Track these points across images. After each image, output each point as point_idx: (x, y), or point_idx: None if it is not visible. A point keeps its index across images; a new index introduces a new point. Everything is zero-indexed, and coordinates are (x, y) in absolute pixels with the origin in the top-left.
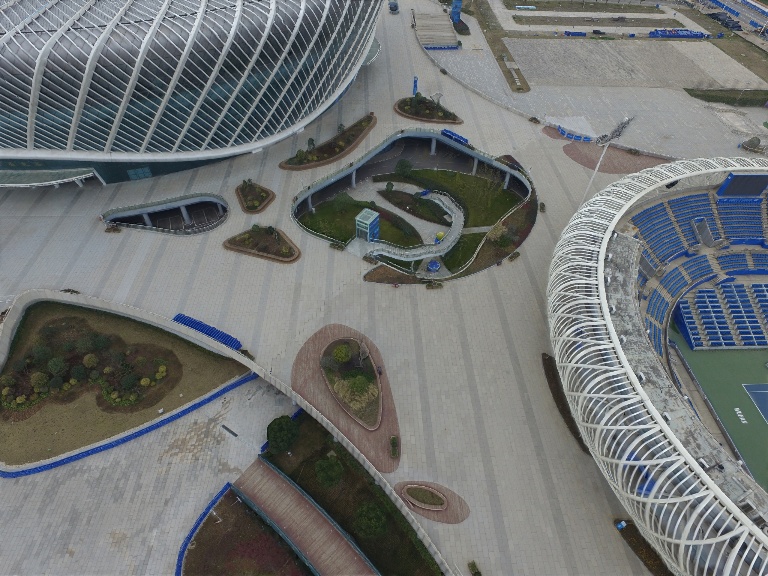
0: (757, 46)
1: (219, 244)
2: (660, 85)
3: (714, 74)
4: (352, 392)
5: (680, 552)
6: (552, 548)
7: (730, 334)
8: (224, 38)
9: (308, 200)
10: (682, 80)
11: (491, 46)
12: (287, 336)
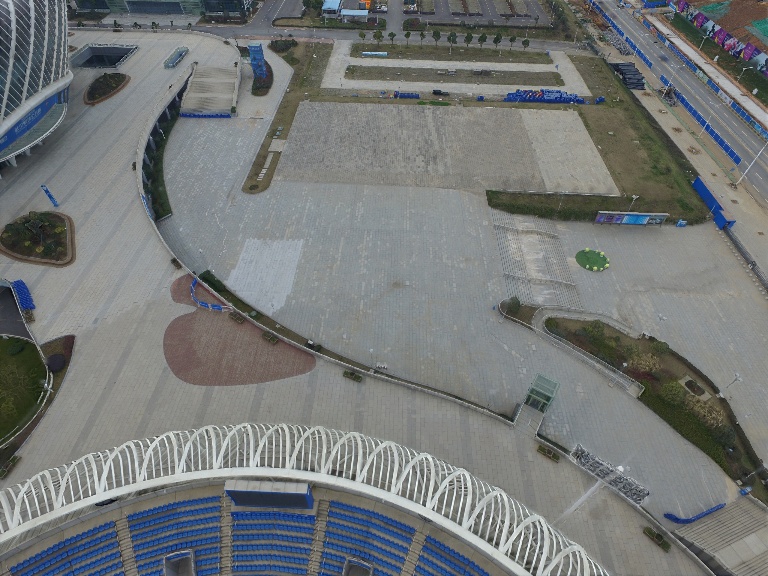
0: (650, 115)
1: None
2: (457, 184)
3: (547, 166)
4: None
5: None
6: None
7: None
8: None
9: None
10: (494, 176)
11: (277, 113)
12: None
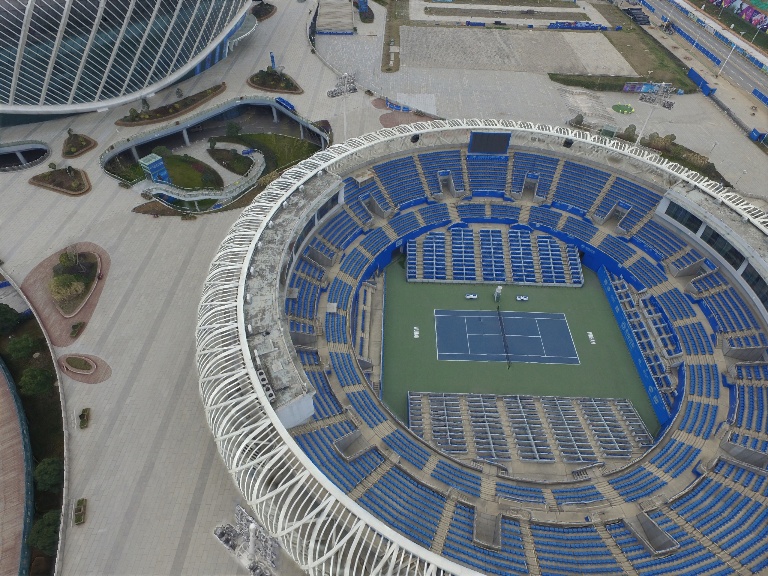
0: (655, 39)
1: (26, 180)
2: (527, 69)
3: (587, 61)
4: (57, 286)
5: (200, 389)
6: (160, 404)
7: (444, 270)
8: (24, 1)
9: (132, 152)
10: (551, 66)
11: (386, 33)
12: (41, 249)
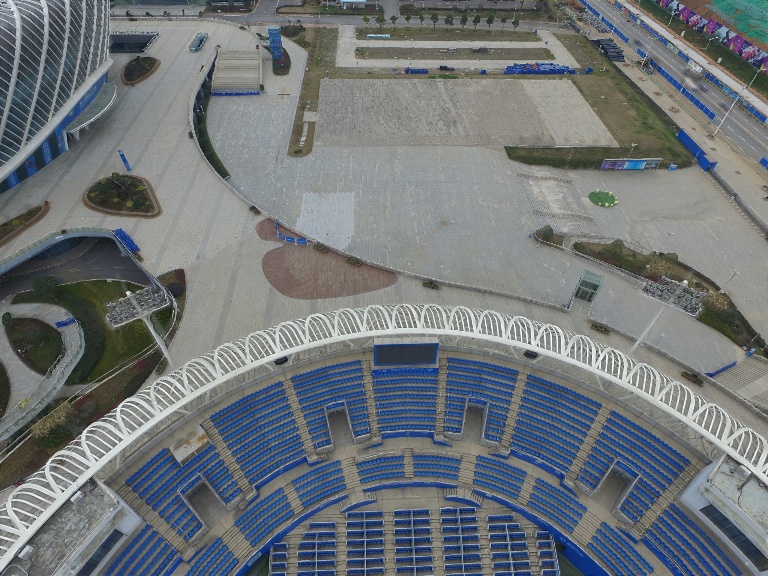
0: (632, 82)
1: None
2: (478, 142)
3: (553, 125)
4: None
5: None
6: None
7: None
8: None
9: None
10: (509, 135)
11: (302, 90)
12: None
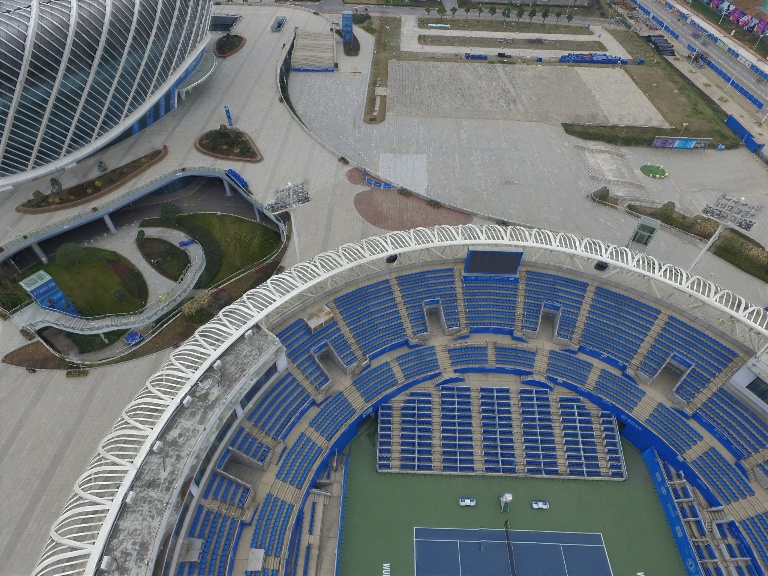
0: (682, 74)
1: None
2: (537, 119)
3: (607, 107)
4: None
5: None
6: None
7: (430, 454)
8: None
9: (34, 249)
10: (565, 113)
11: (372, 69)
12: None
